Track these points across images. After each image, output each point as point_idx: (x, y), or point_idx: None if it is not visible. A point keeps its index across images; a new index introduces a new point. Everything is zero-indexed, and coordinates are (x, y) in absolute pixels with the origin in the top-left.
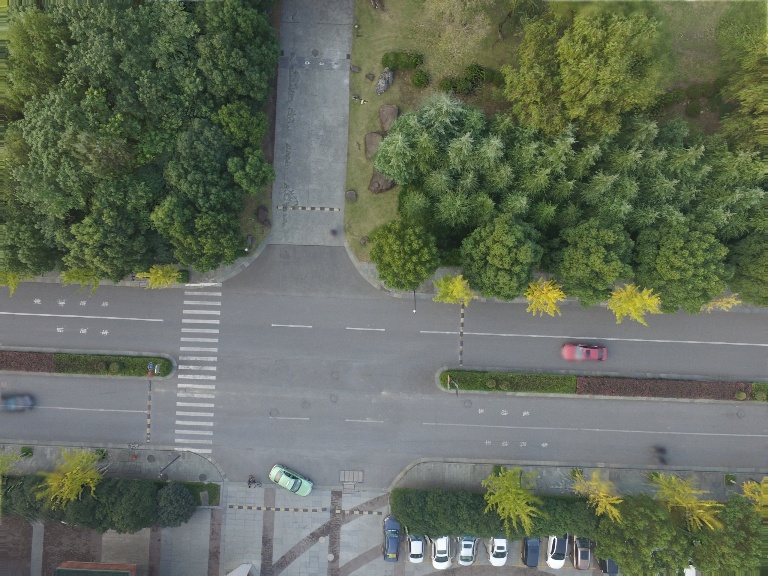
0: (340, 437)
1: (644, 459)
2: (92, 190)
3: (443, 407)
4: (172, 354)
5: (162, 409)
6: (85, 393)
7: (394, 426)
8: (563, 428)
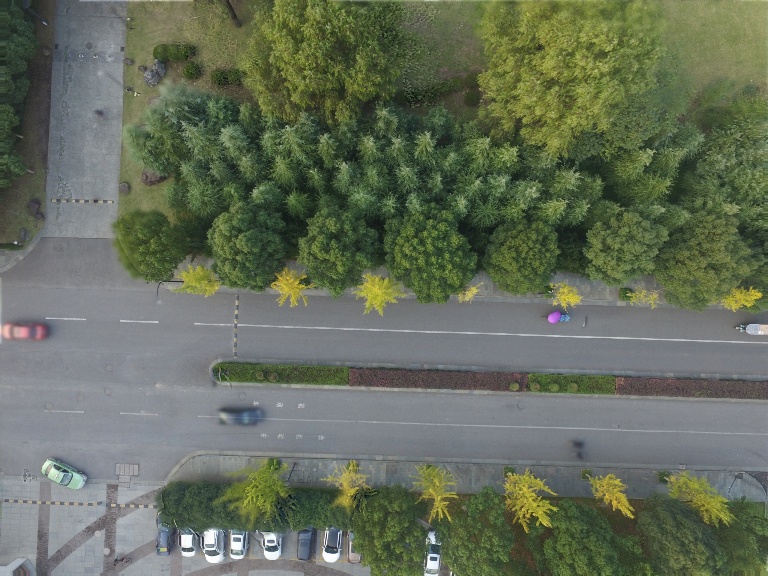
0: (115, 430)
1: (422, 451)
2: None
3: (217, 399)
4: None
5: None
6: None
7: (169, 419)
8: (339, 420)
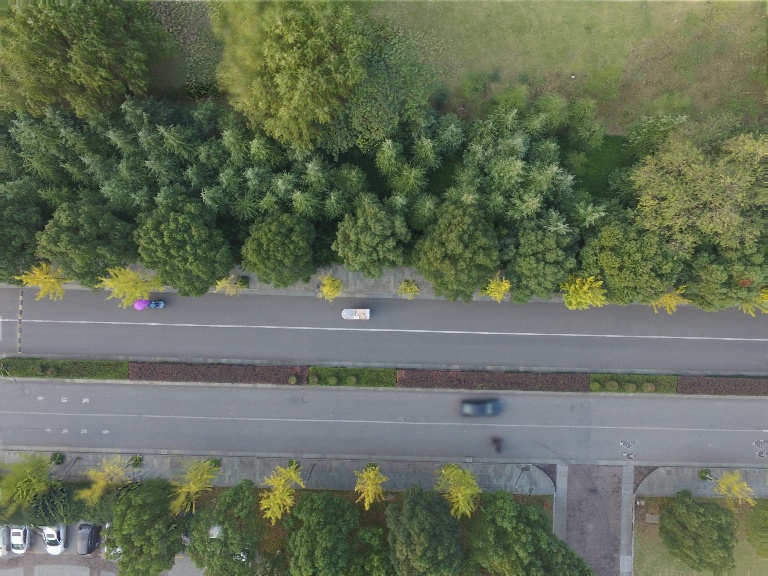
0: None
1: (207, 445)
2: None
3: (2, 395)
4: None
5: None
6: None
7: None
8: (124, 415)
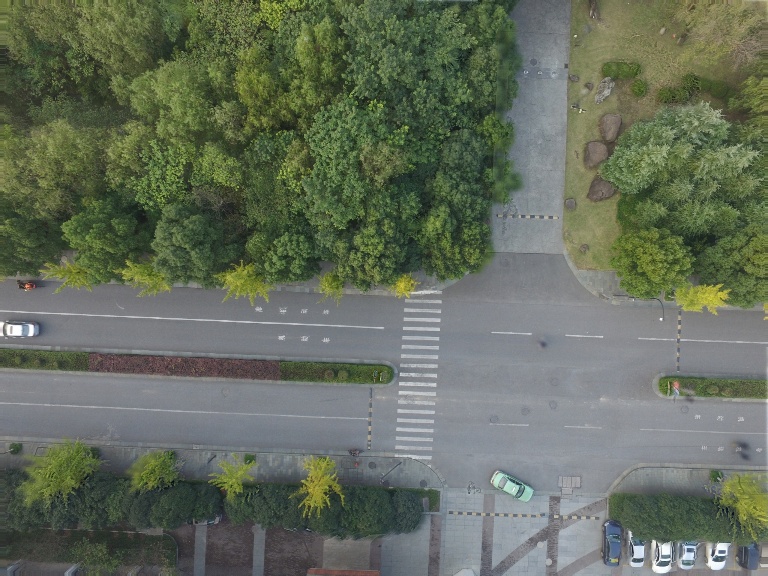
0: (559, 443)
1: None
2: (372, 201)
3: (660, 413)
4: (393, 361)
5: (383, 416)
6: (306, 400)
7: (612, 432)
8: None
